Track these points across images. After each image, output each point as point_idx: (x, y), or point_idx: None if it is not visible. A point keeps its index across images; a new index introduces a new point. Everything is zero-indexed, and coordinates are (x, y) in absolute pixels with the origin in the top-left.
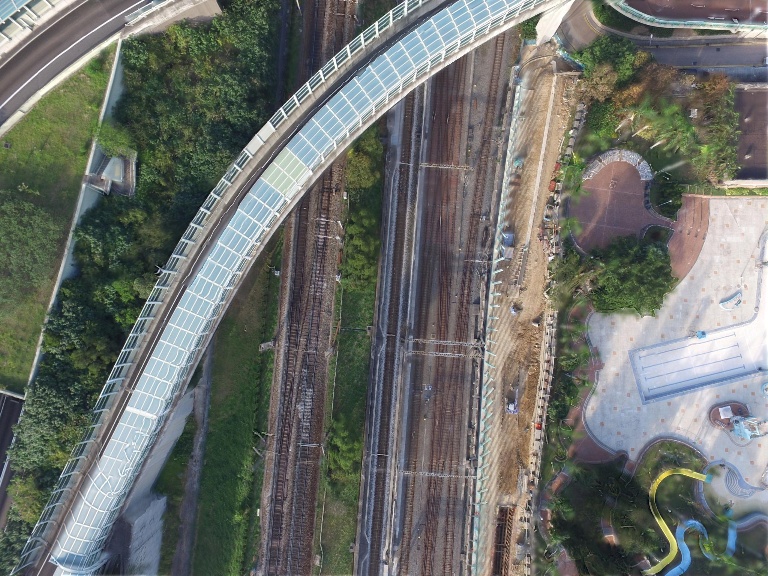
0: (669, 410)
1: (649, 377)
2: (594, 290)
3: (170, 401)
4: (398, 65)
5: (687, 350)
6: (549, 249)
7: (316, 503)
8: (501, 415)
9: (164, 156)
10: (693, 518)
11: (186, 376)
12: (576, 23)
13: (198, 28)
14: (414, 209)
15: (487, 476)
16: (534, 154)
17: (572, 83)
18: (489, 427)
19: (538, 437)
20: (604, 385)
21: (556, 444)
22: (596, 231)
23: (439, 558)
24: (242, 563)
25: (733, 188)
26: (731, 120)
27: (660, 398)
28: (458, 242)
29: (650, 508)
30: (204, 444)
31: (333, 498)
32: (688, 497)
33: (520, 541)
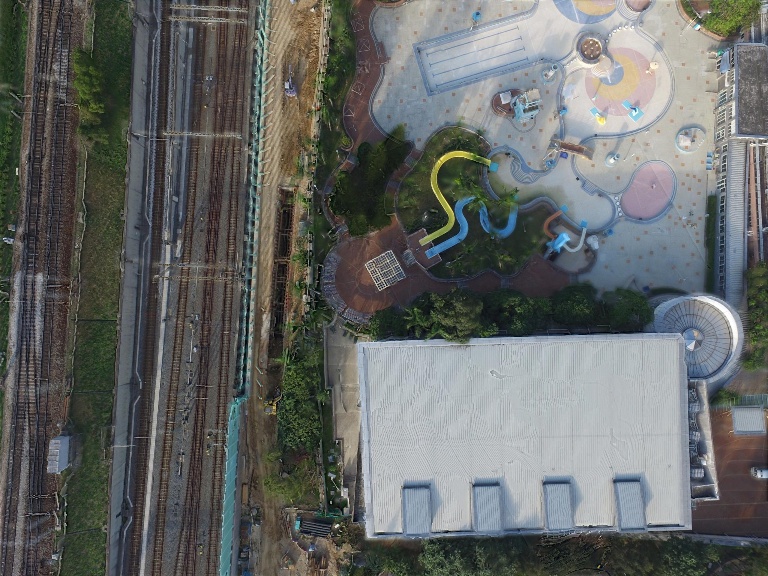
0: (454, 100)
1: (436, 73)
2: None
3: None
4: None
5: (473, 45)
6: None
7: (77, 162)
8: (281, 100)
9: None
10: None
11: None
12: None
13: None
14: None
15: (269, 159)
16: None
17: None
18: (270, 112)
19: (317, 119)
20: (390, 79)
21: (341, 133)
22: None
23: (223, 239)
24: (1, 219)
25: None
26: None
27: (444, 89)
28: None
29: (432, 188)
30: None
31: None
32: None
33: (302, 219)
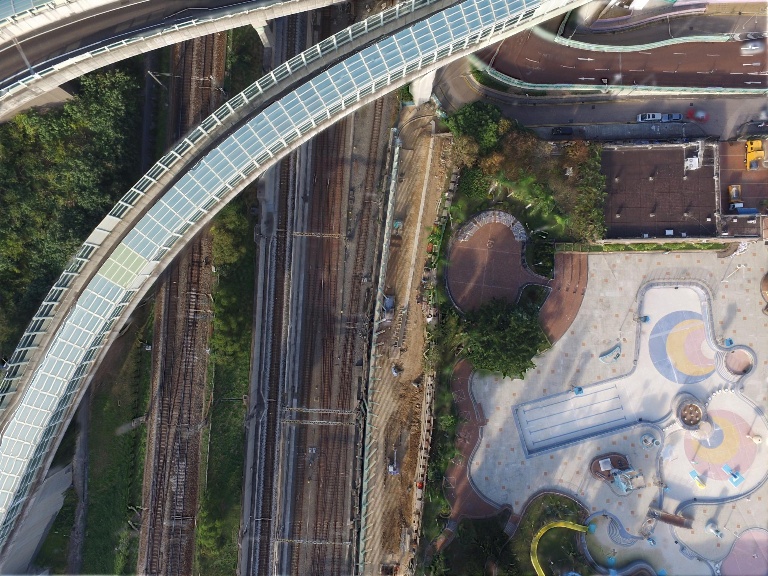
0: (552, 463)
1: (533, 430)
2: (471, 351)
3: (20, 493)
4: (233, 157)
5: (570, 403)
6: (428, 310)
7: (192, 574)
8: (384, 475)
9: (16, 244)
10: (573, 570)
11: (42, 464)
12: (455, 82)
13: (48, 115)
14: (290, 276)
15: (370, 536)
16: (413, 216)
17: (449, 144)
18: (372, 487)
19: (419, 496)
20: (488, 440)
21: (440, 501)
22: (475, 291)
23: None
24: None
25: (609, 244)
26: (598, 182)
27: (543, 452)
28: (340, 304)
29: (531, 562)
30: (85, 516)
31: (209, 569)
32: (569, 549)
33: None
